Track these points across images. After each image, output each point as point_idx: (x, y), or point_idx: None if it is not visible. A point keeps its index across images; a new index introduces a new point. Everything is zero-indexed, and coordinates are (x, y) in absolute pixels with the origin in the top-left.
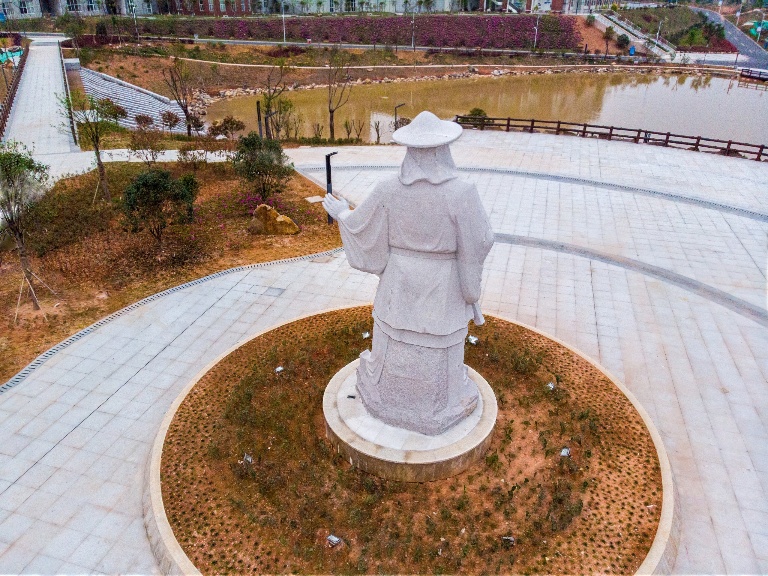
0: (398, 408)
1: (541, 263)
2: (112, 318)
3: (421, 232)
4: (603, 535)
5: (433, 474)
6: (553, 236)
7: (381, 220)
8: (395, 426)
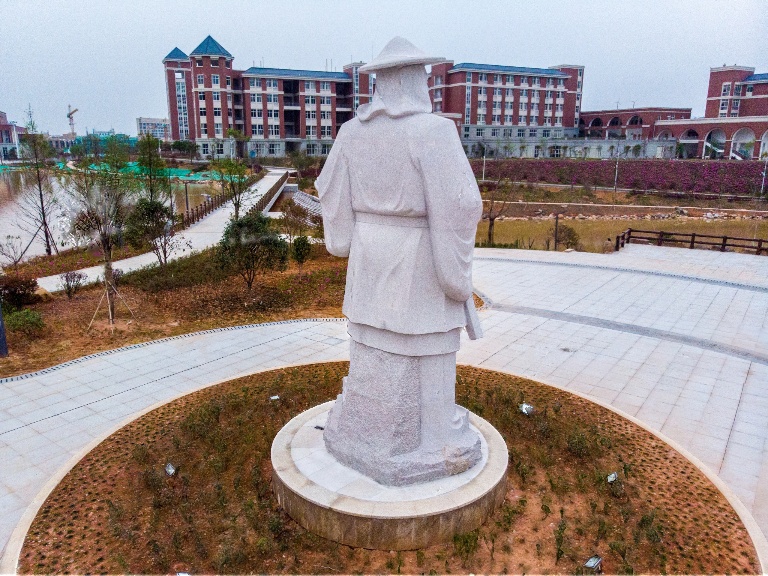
0: (352, 439)
1: (674, 357)
2: (167, 340)
3: (380, 185)
4: None
5: (369, 537)
6: (705, 334)
7: (342, 175)
8: (346, 465)
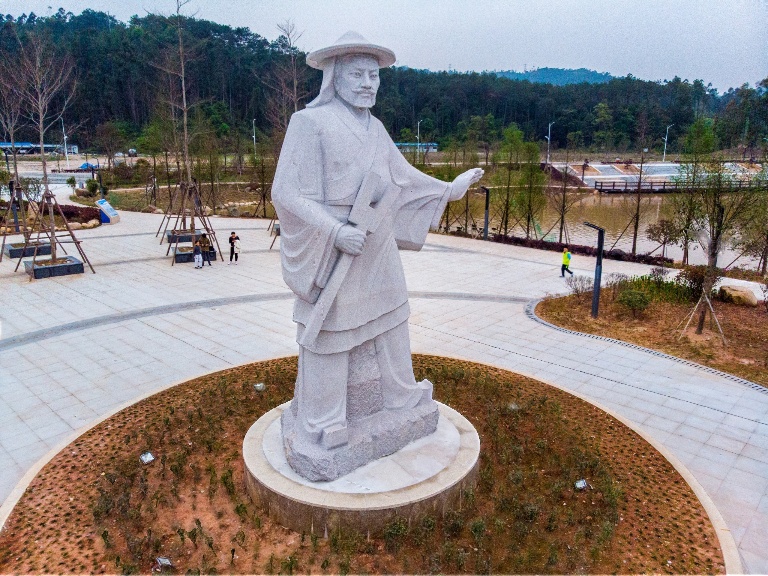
0: None
1: None
2: (688, 363)
3: None
4: (58, 526)
5: None
6: None
7: None
8: None
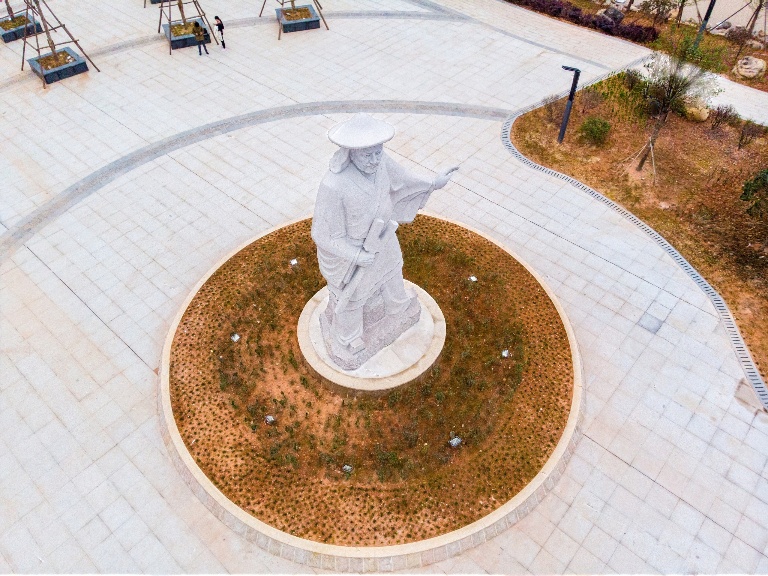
0: None
1: None
2: (618, 209)
3: None
4: (201, 393)
5: None
6: None
7: None
8: None
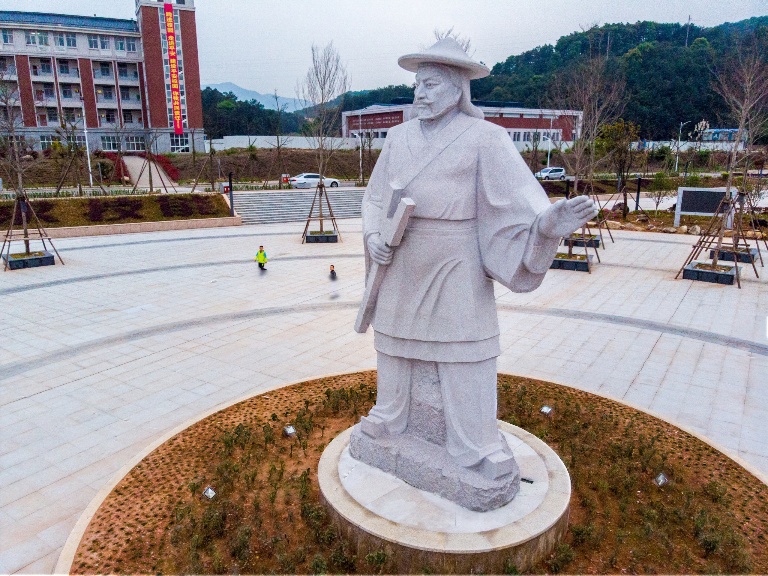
0: None
1: None
2: None
3: None
4: None
5: None
6: None
7: None
8: None
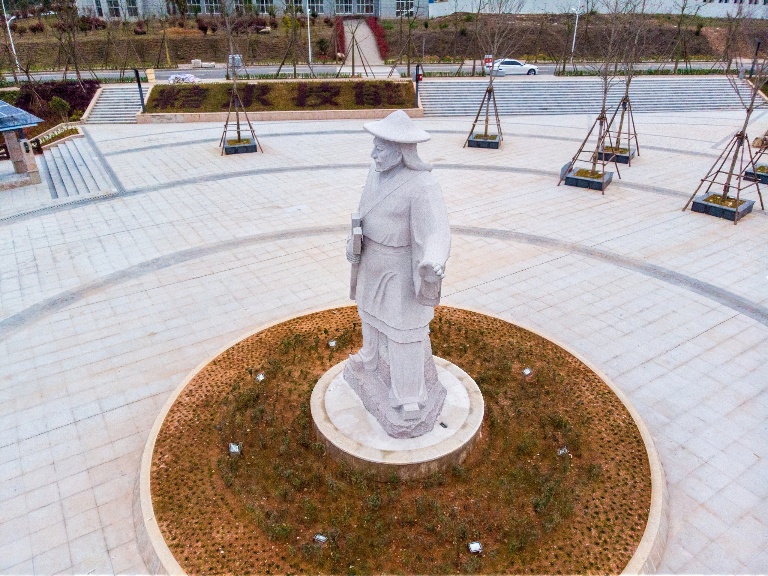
0: None
1: None
2: None
3: None
4: None
5: None
6: None
7: None
8: None
